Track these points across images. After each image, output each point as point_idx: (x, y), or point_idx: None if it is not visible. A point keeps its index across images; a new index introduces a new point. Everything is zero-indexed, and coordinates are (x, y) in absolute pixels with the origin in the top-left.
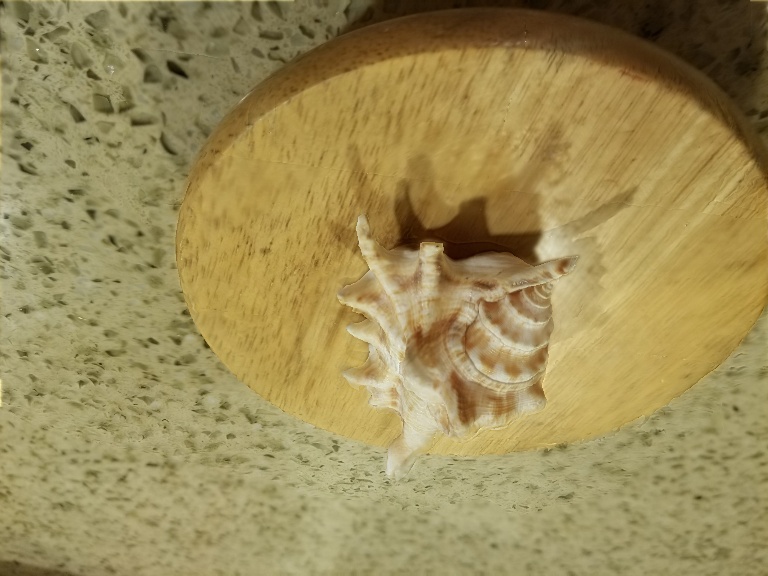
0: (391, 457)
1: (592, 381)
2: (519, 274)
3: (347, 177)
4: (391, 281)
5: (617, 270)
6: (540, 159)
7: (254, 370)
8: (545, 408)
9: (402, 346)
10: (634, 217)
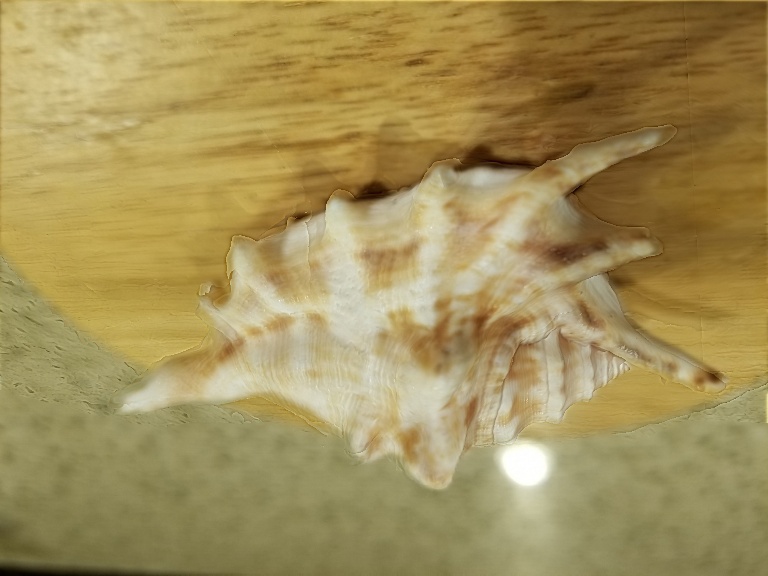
0: (150, 383)
1: None
2: (637, 340)
3: (669, 35)
4: (533, 222)
5: None
6: (763, 242)
7: (2, 62)
8: None
9: (428, 305)
10: (682, 339)
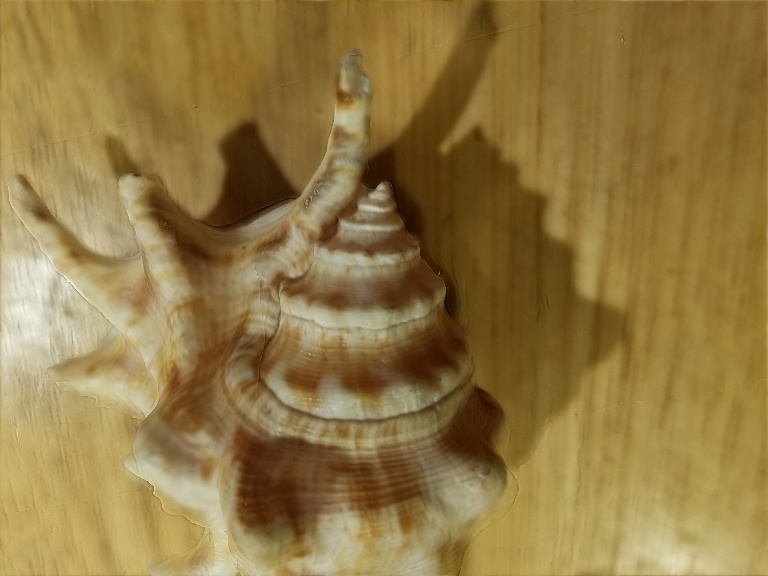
0: None
1: (678, 486)
2: None
3: (28, 163)
4: (118, 303)
5: (561, 191)
6: (293, 2)
7: None
8: (510, 489)
9: None
10: (518, 57)
